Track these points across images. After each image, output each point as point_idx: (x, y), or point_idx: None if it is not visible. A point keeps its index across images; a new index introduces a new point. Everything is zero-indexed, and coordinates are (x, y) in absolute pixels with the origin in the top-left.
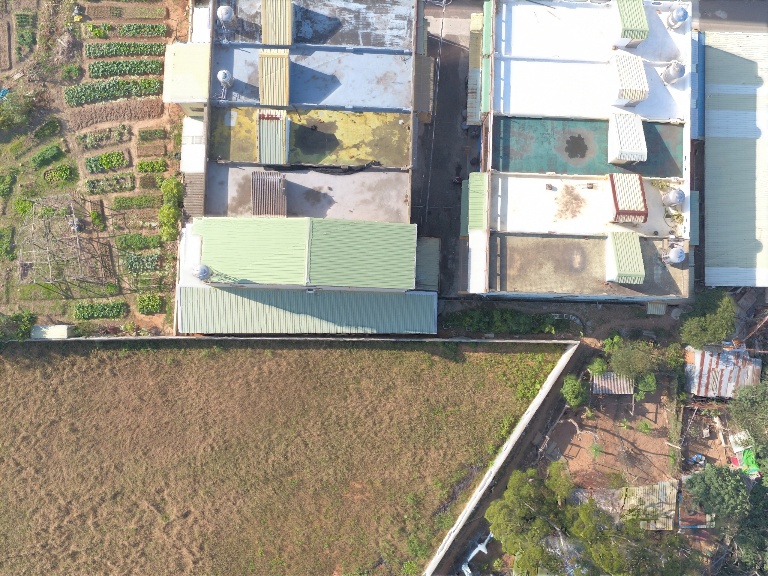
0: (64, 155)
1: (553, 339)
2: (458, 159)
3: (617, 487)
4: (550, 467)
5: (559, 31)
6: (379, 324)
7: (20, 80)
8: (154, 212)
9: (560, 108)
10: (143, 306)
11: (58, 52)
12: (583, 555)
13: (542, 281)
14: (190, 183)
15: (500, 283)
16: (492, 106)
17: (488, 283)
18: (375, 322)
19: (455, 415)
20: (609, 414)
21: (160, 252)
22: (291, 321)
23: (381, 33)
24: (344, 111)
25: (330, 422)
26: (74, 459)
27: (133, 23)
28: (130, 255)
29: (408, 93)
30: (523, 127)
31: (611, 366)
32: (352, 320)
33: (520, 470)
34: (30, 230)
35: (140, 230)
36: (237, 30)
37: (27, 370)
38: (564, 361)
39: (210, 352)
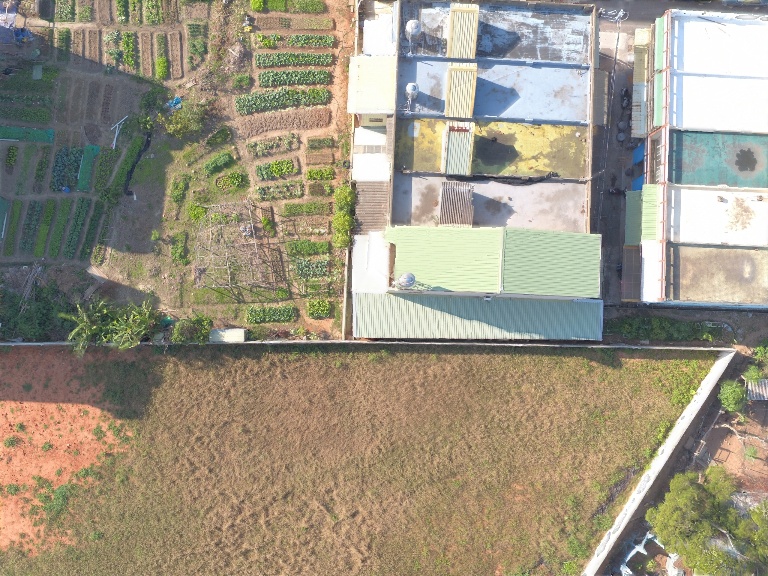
0: (235, 162)
1: (706, 346)
2: (613, 170)
3: (767, 491)
4: (701, 471)
5: (729, 47)
6: (547, 330)
7: (192, 89)
8: (323, 219)
9: (730, 122)
10: (313, 311)
11: (229, 62)
12: (749, 557)
13: (714, 290)
14: (362, 191)
15: (673, 292)
16: (668, 120)
17: (664, 292)
18: (543, 328)
19: (613, 419)
20: (757, 420)
21: (329, 258)
22: (462, 327)
23: (558, 48)
24: (523, 123)
25: (493, 425)
26: (246, 459)
27: (301, 34)
28: (300, 261)
29: (584, 106)
30: (695, 141)
31: (766, 373)
32: (521, 326)
33: (682, 474)
34: (203, 235)
35: (309, 236)
36: (420, 43)
37: (200, 372)
38: (722, 368)
39: (378, 356)
